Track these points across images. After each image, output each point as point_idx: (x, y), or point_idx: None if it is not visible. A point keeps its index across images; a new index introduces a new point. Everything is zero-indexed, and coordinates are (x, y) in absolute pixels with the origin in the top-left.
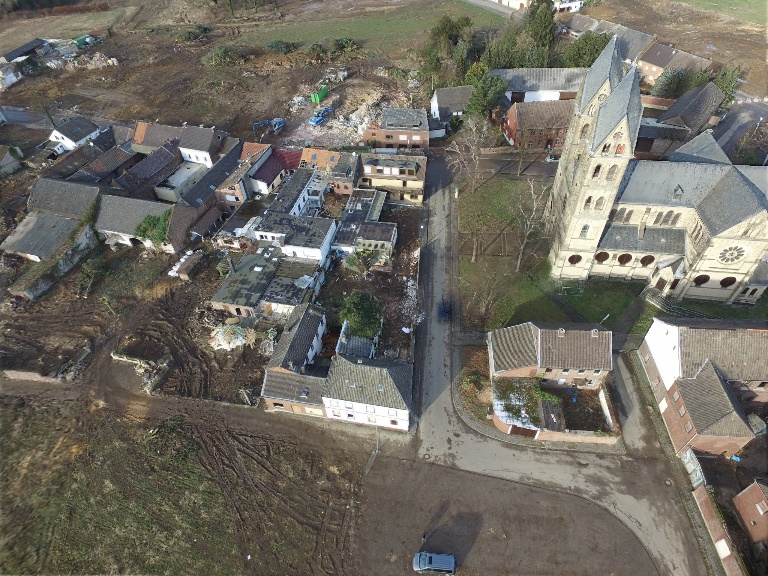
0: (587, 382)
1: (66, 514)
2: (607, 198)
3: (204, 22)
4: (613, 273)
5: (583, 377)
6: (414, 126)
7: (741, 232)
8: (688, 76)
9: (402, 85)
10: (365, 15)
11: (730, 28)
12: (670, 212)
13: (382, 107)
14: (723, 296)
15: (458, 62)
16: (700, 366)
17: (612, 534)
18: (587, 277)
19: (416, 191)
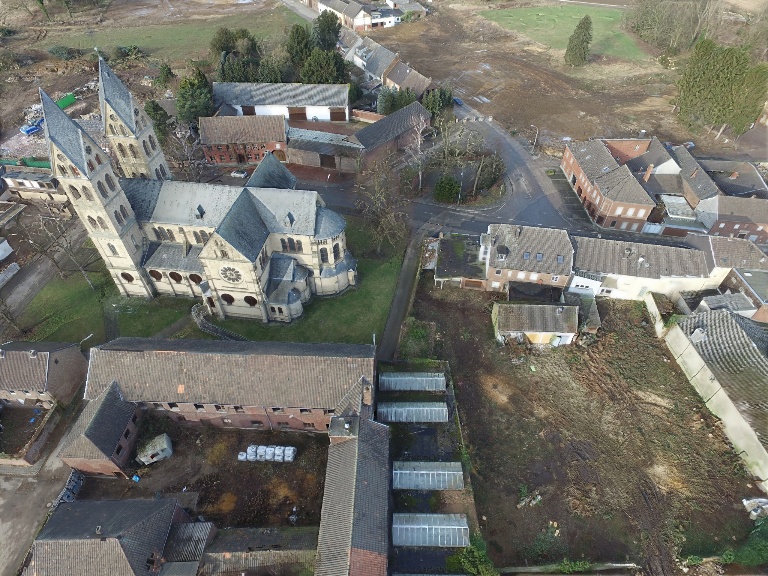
0: (45, 402)
1: None
2: (104, 218)
3: (17, 24)
4: (178, 290)
5: (35, 397)
6: None
7: (219, 253)
8: (399, 95)
9: (158, 95)
10: (185, 23)
11: (517, 48)
12: (203, 231)
13: None
14: (259, 314)
15: (196, 74)
16: (105, 387)
17: None
18: (151, 294)
19: None
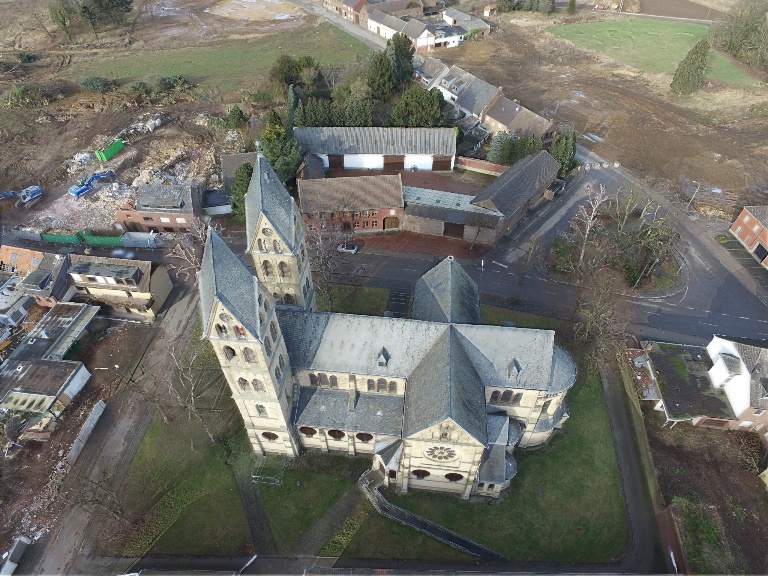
0: None
1: None
2: (263, 380)
3: (36, 48)
4: (332, 446)
5: None
6: (175, 207)
7: (437, 434)
8: (521, 142)
9: (218, 138)
10: (225, 44)
11: (606, 72)
12: (382, 379)
13: (176, 170)
14: (457, 488)
15: (270, 116)
16: None
17: None
18: (297, 453)
19: (138, 305)
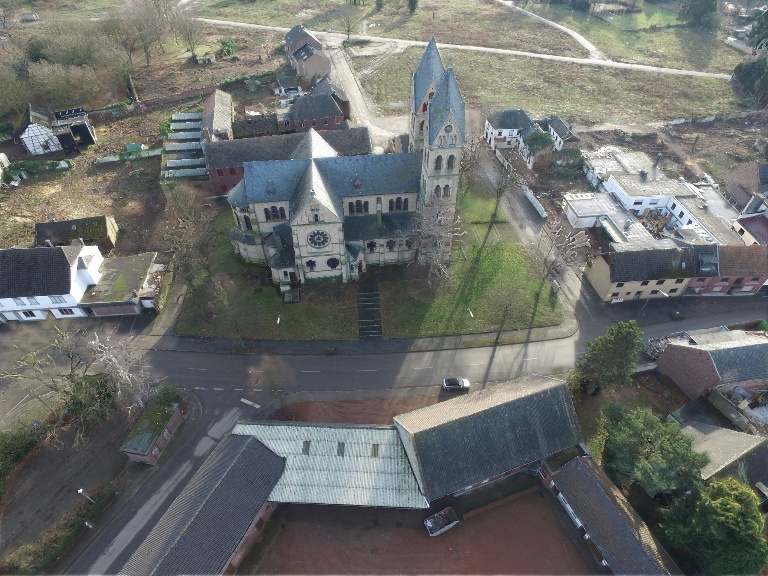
0: None
1: (592, 105)
2: None
3: None
4: None
5: None
6: None
7: None
8: None
9: None
10: None
11: None
12: None
13: None
14: None
15: None
16: None
17: (391, 128)
18: None
19: None
